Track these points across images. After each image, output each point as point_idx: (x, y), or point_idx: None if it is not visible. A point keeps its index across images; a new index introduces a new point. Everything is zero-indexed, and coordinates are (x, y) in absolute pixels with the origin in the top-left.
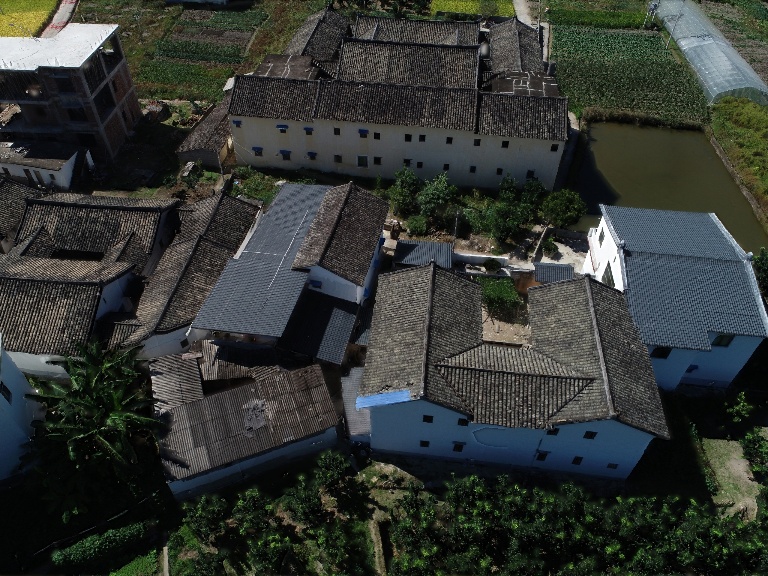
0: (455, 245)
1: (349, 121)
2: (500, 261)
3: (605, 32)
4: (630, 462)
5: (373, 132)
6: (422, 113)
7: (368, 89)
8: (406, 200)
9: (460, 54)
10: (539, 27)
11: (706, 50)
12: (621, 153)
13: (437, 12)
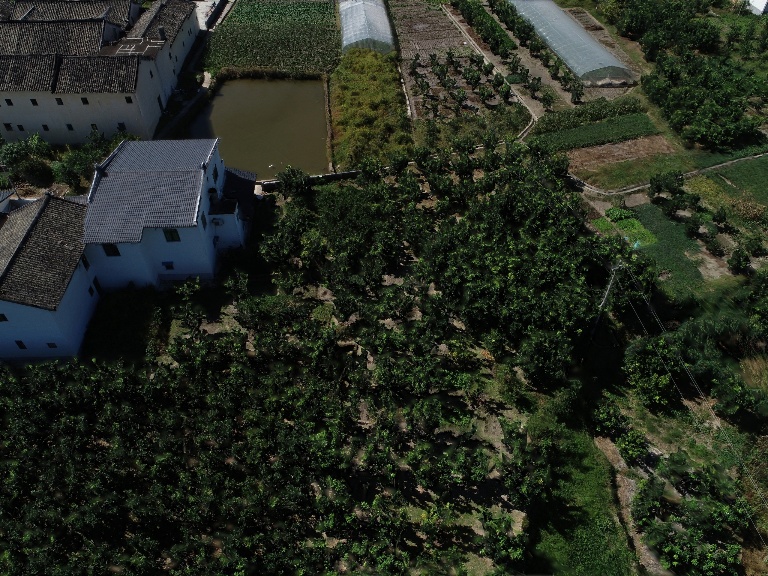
0: (34, 194)
1: None
2: None
3: (285, 2)
4: (60, 339)
5: None
6: (3, 79)
7: None
8: None
9: (86, 27)
10: (220, 1)
11: (353, 10)
12: (239, 104)
13: None
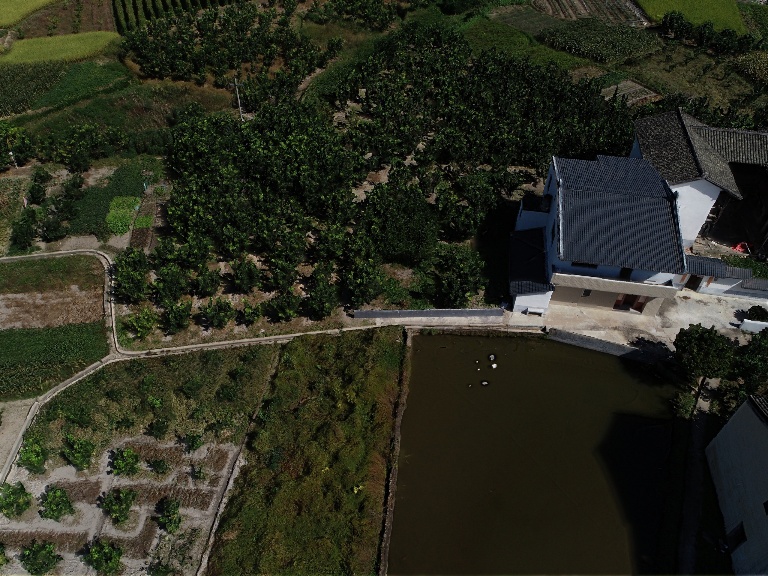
0: None
1: None
2: None
3: None
4: None
5: None
6: None
7: None
8: None
9: None
10: None
11: None
12: None
13: None
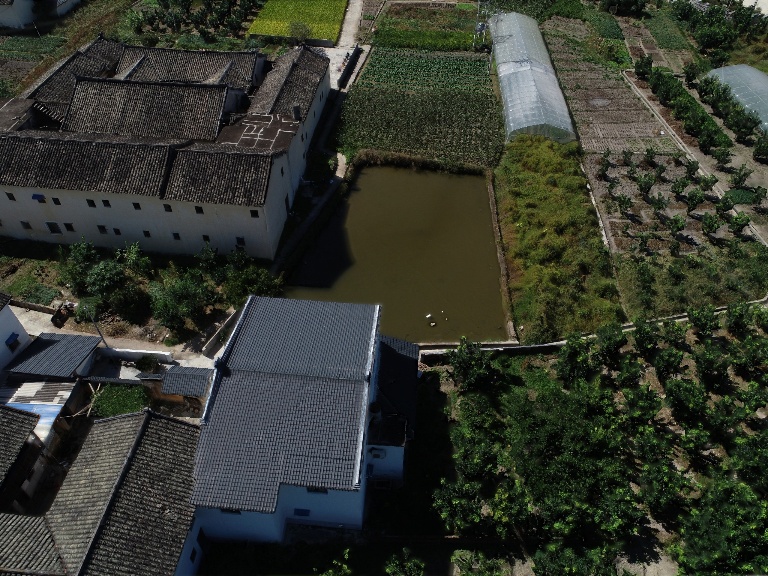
0: (126, 333)
1: (17, 186)
2: (161, 357)
3: (429, 55)
4: None
5: (50, 197)
6: (103, 175)
7: (47, 146)
8: (77, 279)
9: (205, 94)
10: (354, 51)
11: (519, 78)
12: (381, 205)
13: (250, 35)
